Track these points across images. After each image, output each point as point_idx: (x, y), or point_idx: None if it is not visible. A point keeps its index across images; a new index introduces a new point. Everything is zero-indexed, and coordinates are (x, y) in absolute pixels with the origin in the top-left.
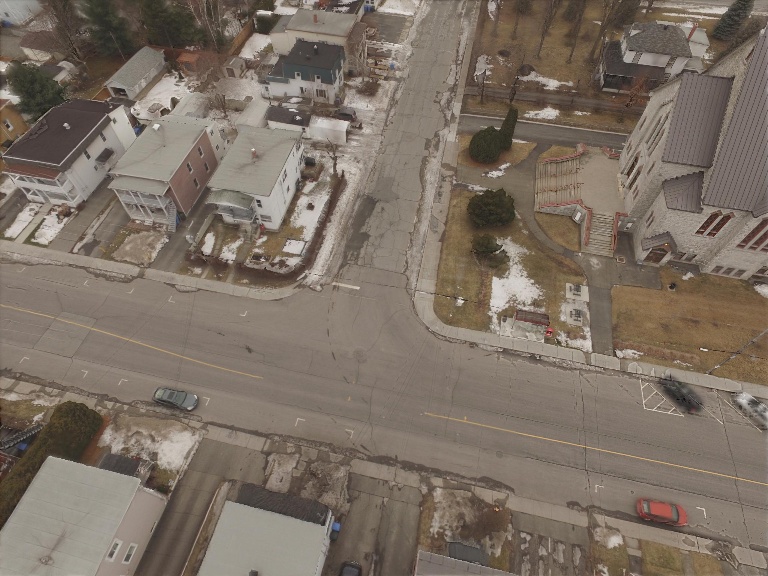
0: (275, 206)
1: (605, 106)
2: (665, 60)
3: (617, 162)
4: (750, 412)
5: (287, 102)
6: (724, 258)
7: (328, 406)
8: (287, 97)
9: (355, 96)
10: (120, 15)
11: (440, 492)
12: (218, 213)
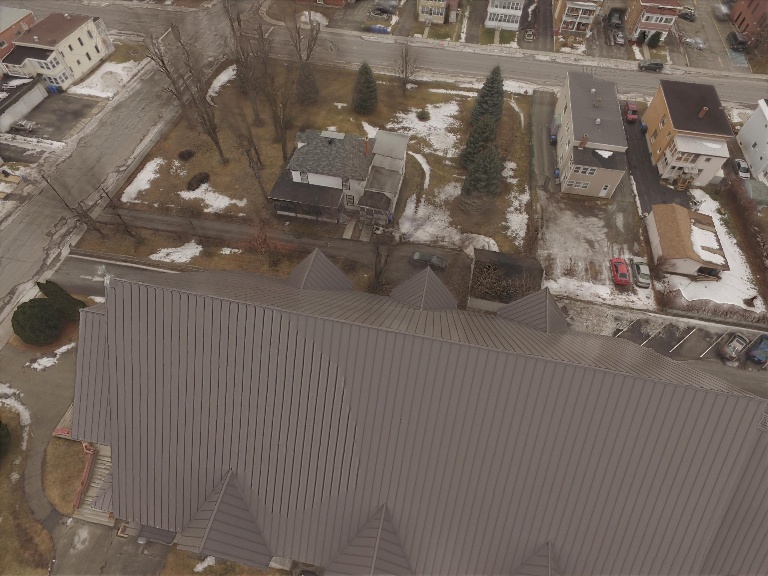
0: None
1: None
2: (337, 181)
3: None
4: None
5: None
6: None
7: None
8: None
9: None
10: None
11: None
12: None
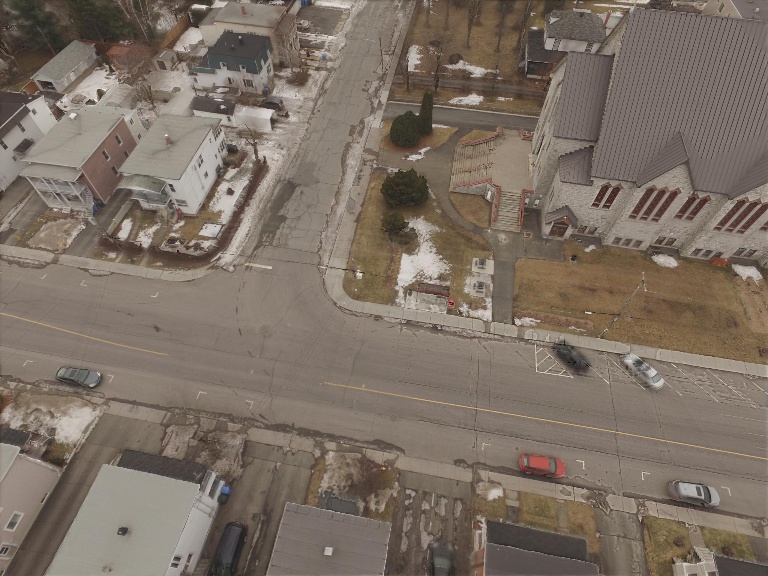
0: (190, 190)
1: (528, 92)
2: (583, 46)
3: (530, 143)
4: (635, 371)
5: (213, 92)
6: (620, 229)
7: (230, 379)
8: (214, 87)
9: (284, 86)
10: (46, 9)
11: (332, 455)
12: (133, 198)
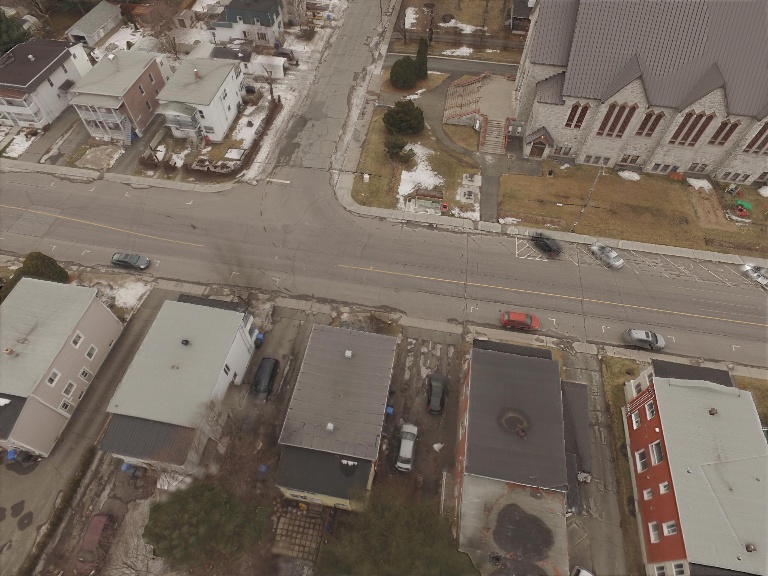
0: (216, 118)
1: (513, 45)
2: None
3: (514, 83)
4: (599, 255)
5: (231, 43)
6: (590, 147)
7: (259, 263)
8: (231, 40)
9: (294, 41)
10: None
11: (346, 315)
12: (167, 125)
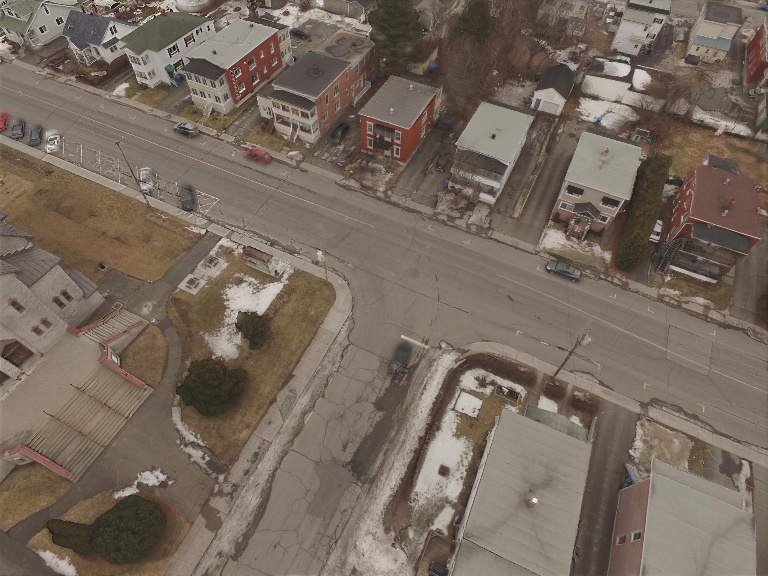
0: None
1: None
2: None
3: None
4: (152, 180)
5: None
6: None
7: (445, 245)
8: None
9: None
10: None
11: (381, 188)
12: None
